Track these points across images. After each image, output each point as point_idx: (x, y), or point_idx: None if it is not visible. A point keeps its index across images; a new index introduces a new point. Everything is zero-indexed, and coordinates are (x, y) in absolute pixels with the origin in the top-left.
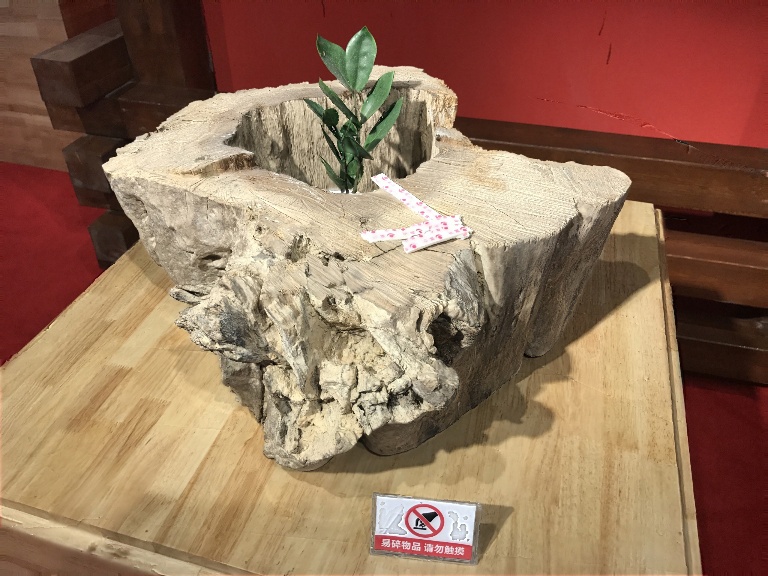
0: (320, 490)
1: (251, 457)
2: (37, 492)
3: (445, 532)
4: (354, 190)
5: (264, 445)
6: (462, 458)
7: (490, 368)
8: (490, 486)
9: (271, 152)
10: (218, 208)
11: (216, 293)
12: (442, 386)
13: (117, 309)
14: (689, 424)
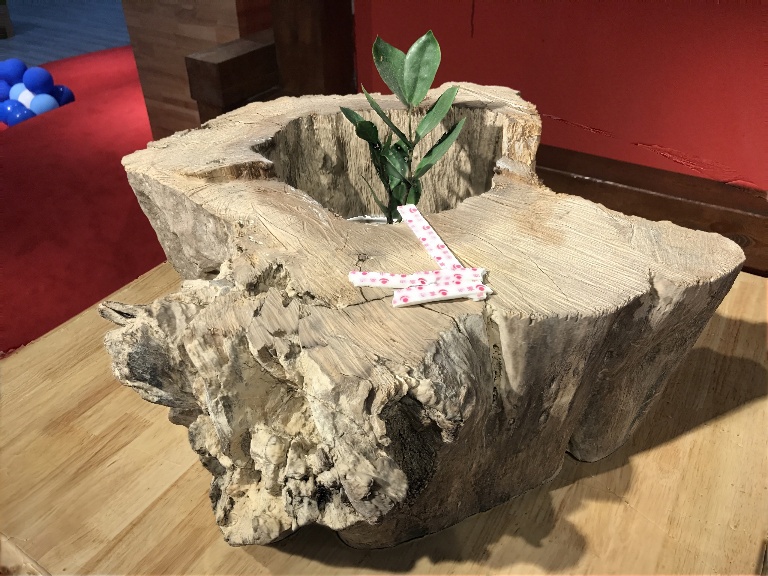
0: (264, 571)
1: (206, 509)
2: None
3: None
4: (398, 220)
5: None
6: (447, 575)
7: (507, 468)
8: None
9: (323, 166)
10: (212, 219)
11: (140, 318)
12: (375, 495)
13: None
14: None
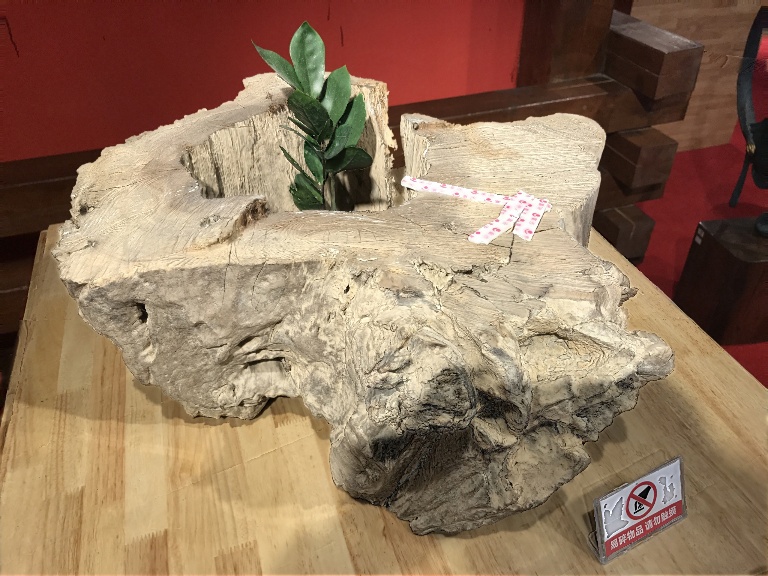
0: (502, 535)
1: (405, 545)
2: None
3: (659, 500)
4: None
5: (414, 523)
6: None
7: None
8: (628, 442)
9: None
10: (278, 272)
11: (429, 358)
12: None
13: (73, 472)
14: (692, 316)
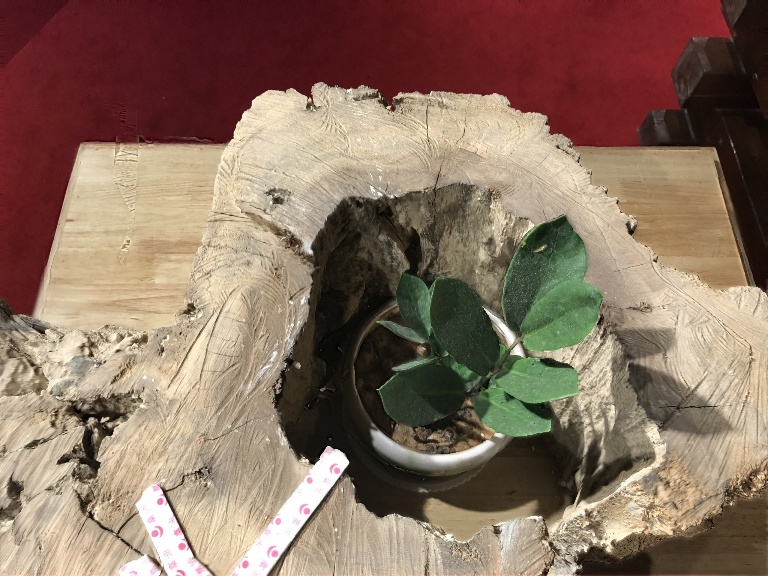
0: None
1: None
2: (68, 259)
3: None
4: None
5: None
6: None
7: None
8: None
9: (488, 243)
10: None
11: None
12: None
13: None
14: None
